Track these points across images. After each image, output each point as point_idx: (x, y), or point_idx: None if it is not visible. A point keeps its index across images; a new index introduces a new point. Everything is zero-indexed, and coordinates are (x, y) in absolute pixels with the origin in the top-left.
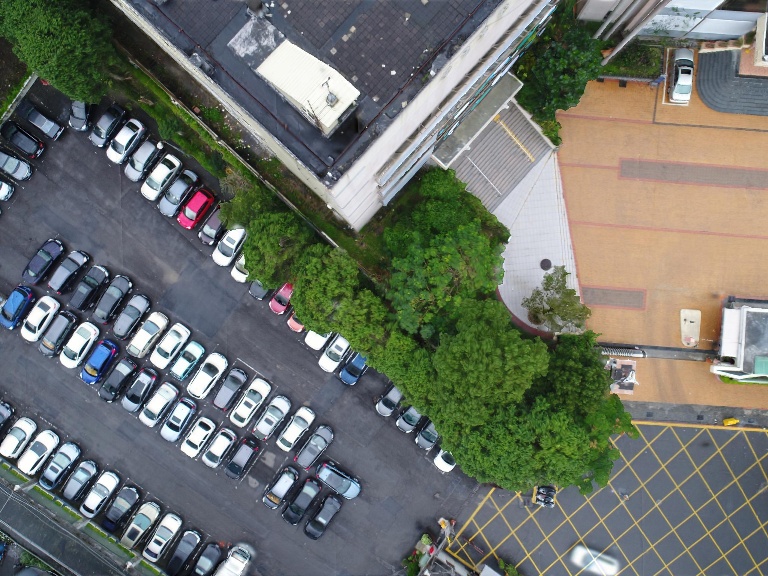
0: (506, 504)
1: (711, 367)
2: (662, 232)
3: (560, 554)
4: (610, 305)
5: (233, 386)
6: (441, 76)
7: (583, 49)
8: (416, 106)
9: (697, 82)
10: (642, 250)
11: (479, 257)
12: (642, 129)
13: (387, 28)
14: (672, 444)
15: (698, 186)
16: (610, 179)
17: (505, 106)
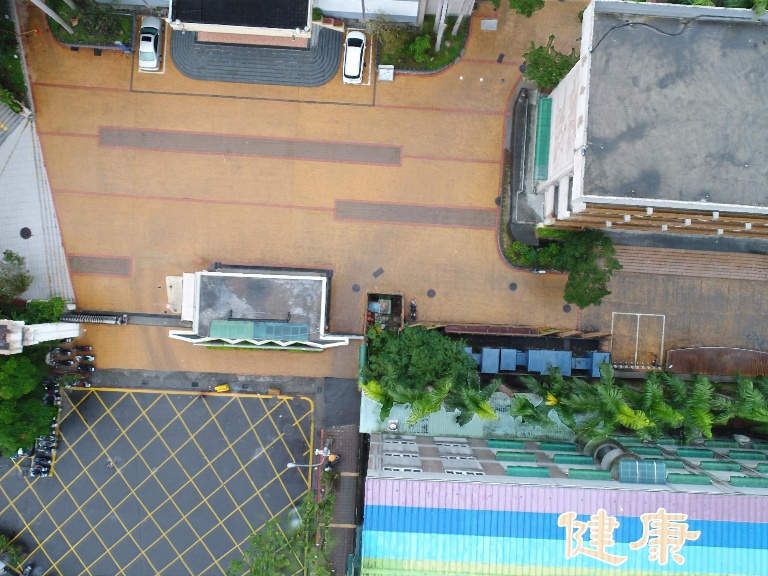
0: (4, 475)
1: None
2: (144, 199)
3: (59, 524)
4: (97, 273)
5: None
6: None
7: None
8: None
9: (171, 50)
10: (125, 218)
11: None
12: (120, 97)
13: None
14: (167, 411)
15: (178, 153)
16: (90, 147)
17: None
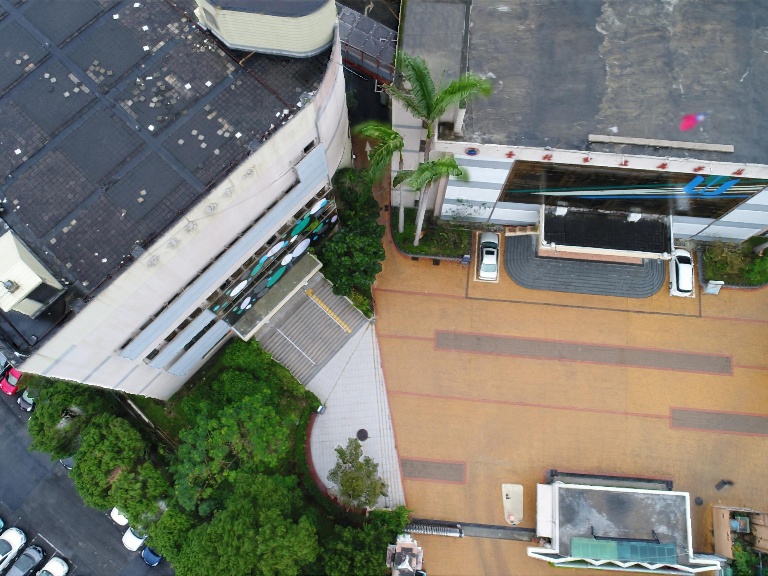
0: None
1: (527, 549)
2: (479, 403)
3: None
4: (430, 478)
5: (24, 566)
6: (146, 264)
7: (370, 234)
8: (124, 290)
9: (505, 262)
10: (460, 421)
11: (259, 429)
12: (456, 303)
13: (104, 222)
14: None
15: (512, 358)
16: (426, 350)
17: (304, 283)
